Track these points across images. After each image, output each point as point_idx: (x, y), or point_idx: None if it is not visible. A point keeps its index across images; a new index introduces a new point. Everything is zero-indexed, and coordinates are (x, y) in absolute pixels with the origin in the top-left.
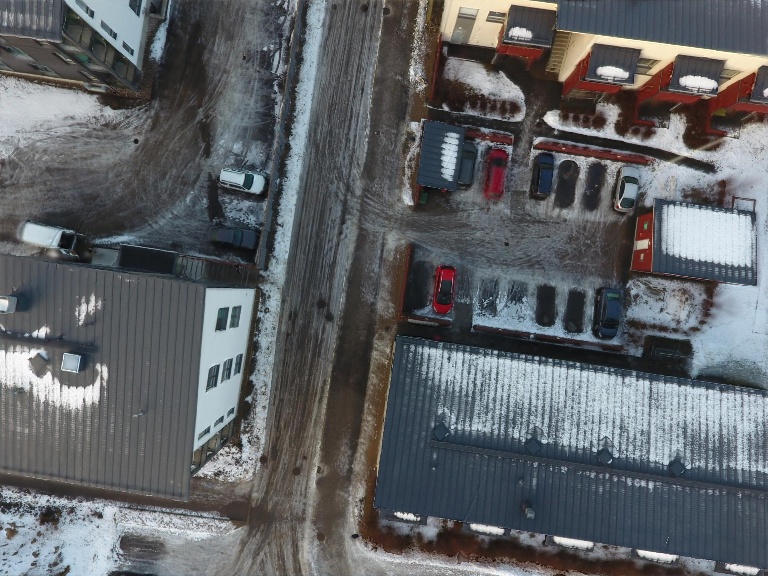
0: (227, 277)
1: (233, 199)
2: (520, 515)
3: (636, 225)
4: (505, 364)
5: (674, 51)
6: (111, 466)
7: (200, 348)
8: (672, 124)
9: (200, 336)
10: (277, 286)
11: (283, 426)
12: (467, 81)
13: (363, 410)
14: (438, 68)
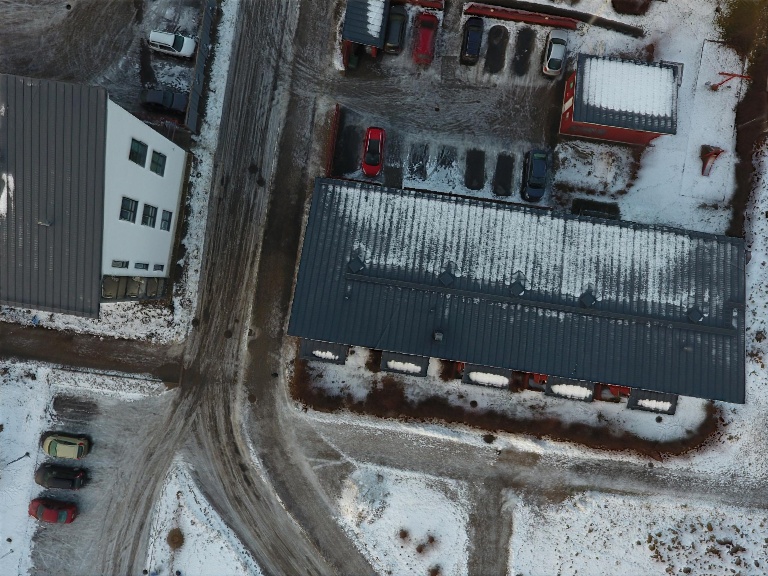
0: None
1: (165, 64)
2: (431, 343)
3: (565, 89)
4: (422, 203)
5: None
6: (21, 282)
7: (104, 157)
8: None
9: (103, 143)
10: (209, 151)
11: (215, 290)
12: None
13: (294, 273)
14: None
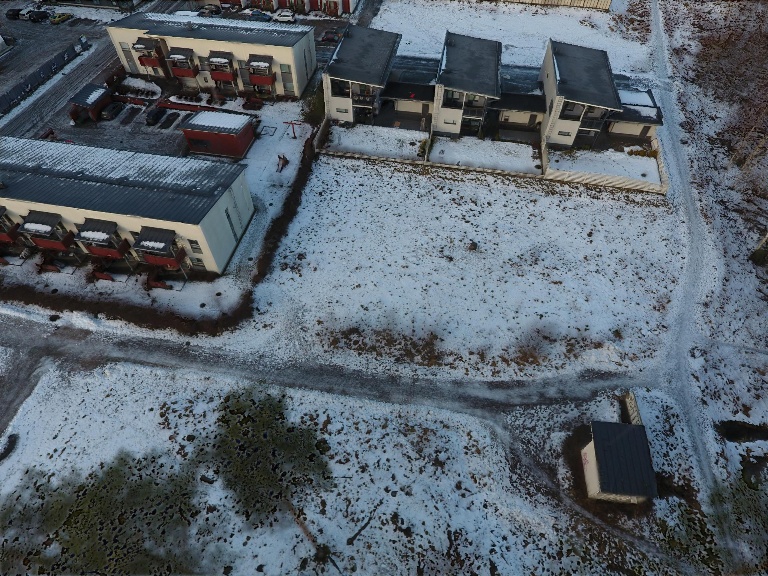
0: None
1: None
2: None
3: None
4: None
5: (206, 48)
6: None
7: None
8: (237, 100)
9: None
10: None
11: None
12: (133, 85)
13: None
14: (120, 80)
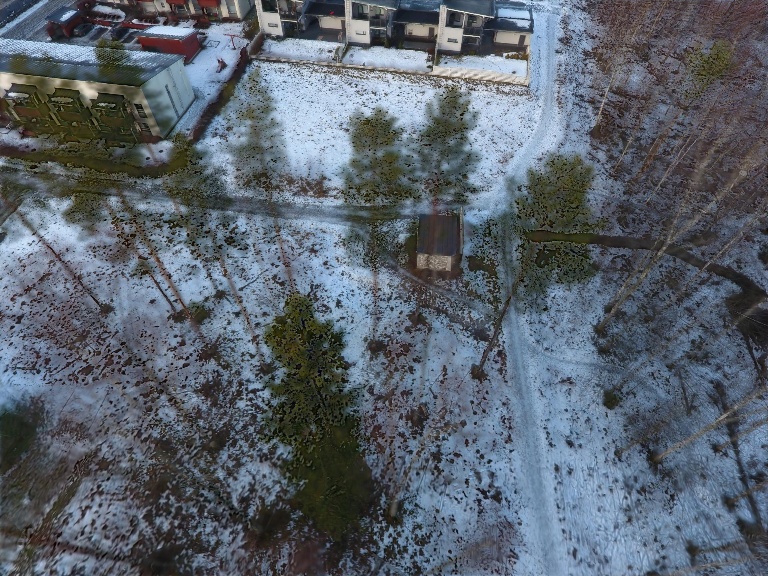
0: None
1: None
2: None
3: None
4: None
5: None
6: None
7: None
8: (189, 22)
9: None
10: None
11: None
12: (102, 11)
13: None
14: (91, 7)
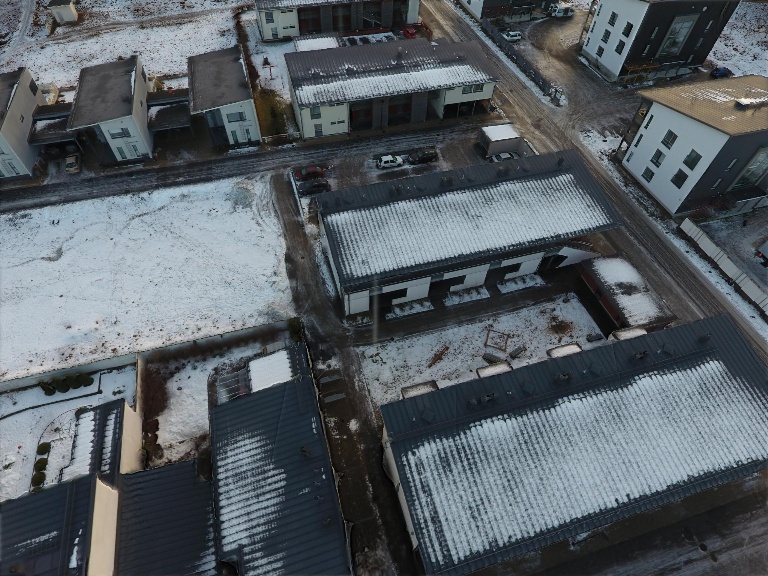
0: (491, 8)
1: None
2: None
3: None
4: None
5: None
6: None
7: None
8: None
9: None
10: None
11: None
12: None
13: None
14: None
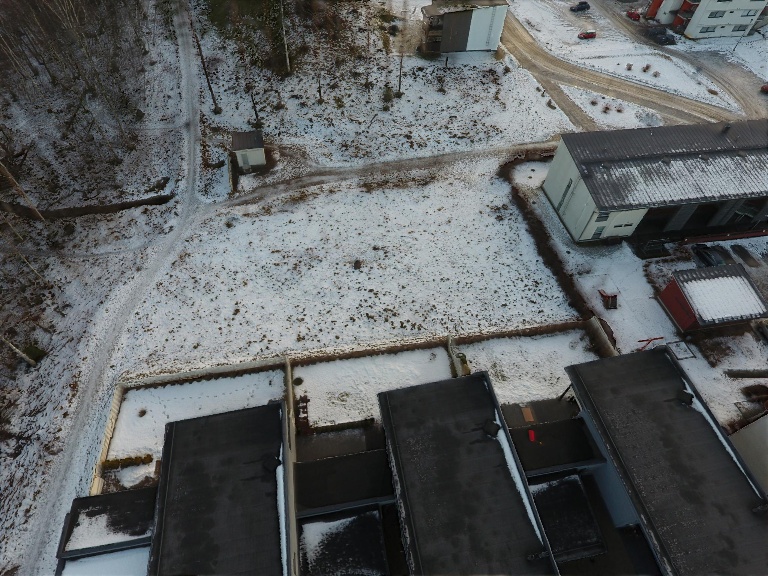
0: None
1: None
2: None
3: None
4: None
5: None
6: None
7: None
8: None
9: None
10: None
11: None
12: None
13: None
14: None
